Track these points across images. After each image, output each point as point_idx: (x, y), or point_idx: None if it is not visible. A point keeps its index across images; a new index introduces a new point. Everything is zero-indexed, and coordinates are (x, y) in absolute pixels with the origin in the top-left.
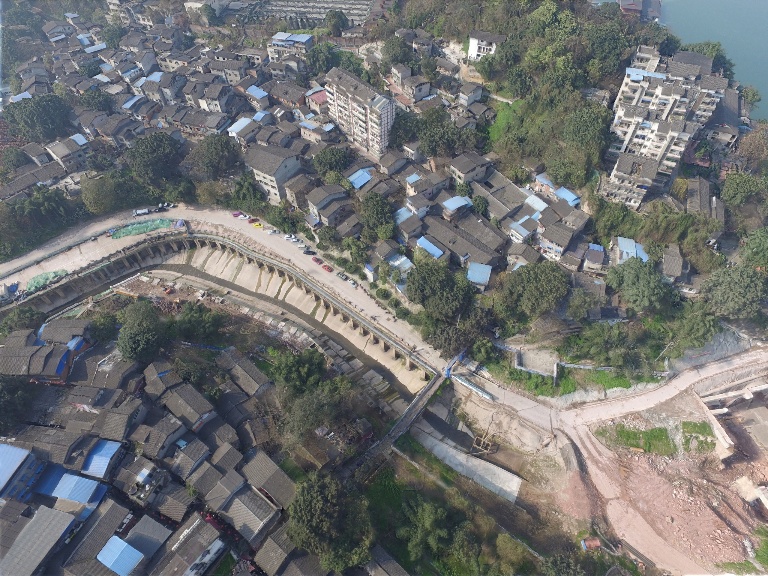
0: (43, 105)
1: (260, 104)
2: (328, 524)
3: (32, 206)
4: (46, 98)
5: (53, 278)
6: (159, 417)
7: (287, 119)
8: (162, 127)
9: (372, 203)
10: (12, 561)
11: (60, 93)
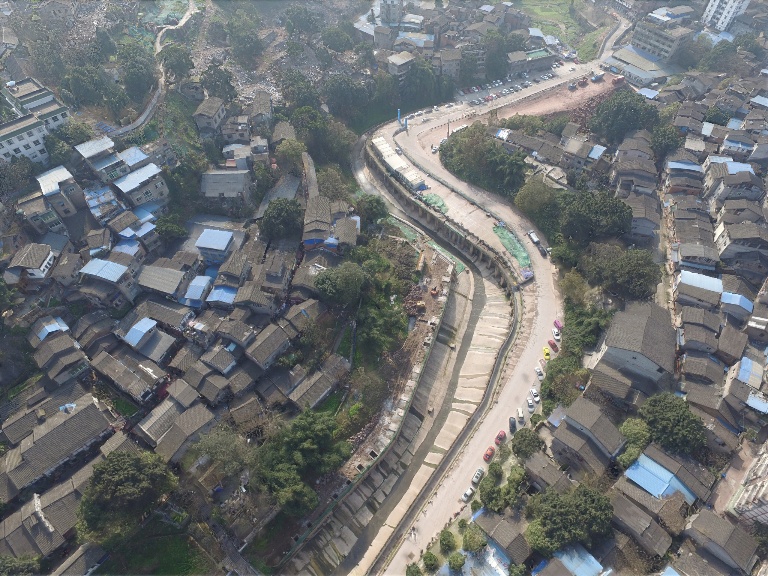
0: (622, 108)
1: (765, 293)
2: (98, 490)
3: (499, 159)
4: (637, 106)
5: (438, 206)
6: (257, 323)
7: (759, 338)
8: (666, 207)
9: (580, 502)
10: (152, 271)
11: (663, 112)
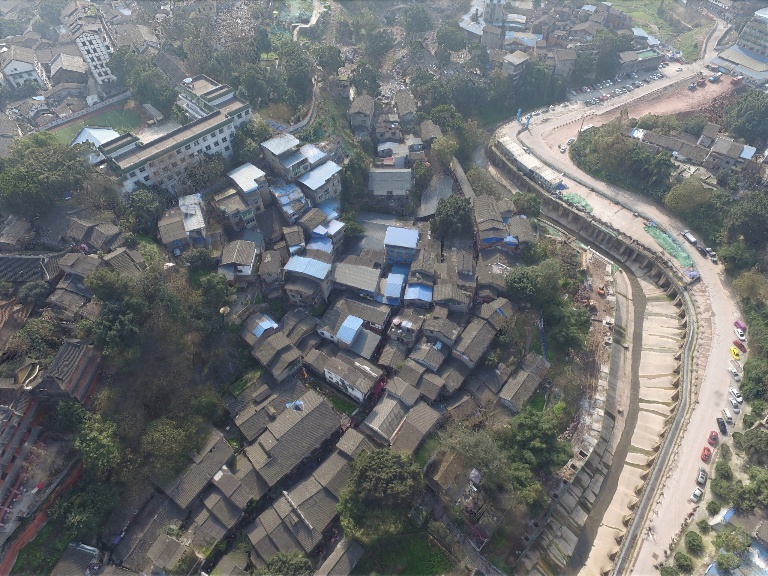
0: None
1: None
2: (368, 487)
3: (644, 159)
4: None
5: (581, 206)
6: (459, 321)
7: None
8: None
9: None
10: (347, 269)
11: None
